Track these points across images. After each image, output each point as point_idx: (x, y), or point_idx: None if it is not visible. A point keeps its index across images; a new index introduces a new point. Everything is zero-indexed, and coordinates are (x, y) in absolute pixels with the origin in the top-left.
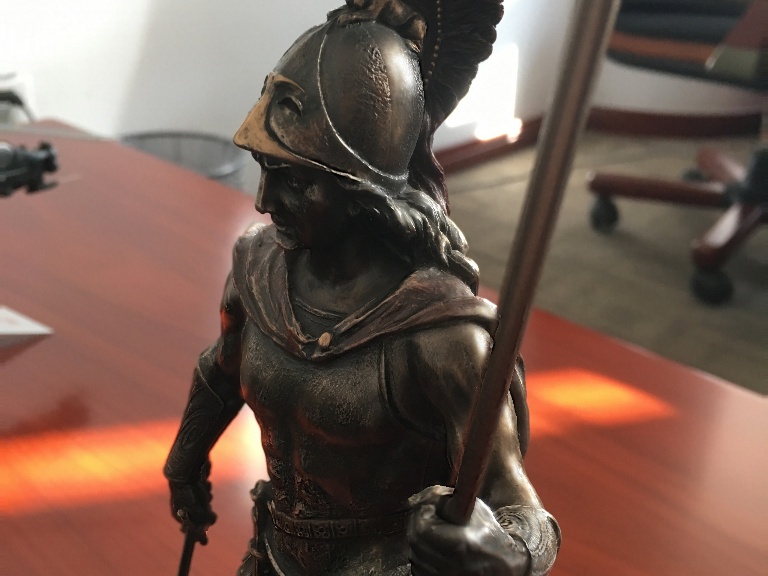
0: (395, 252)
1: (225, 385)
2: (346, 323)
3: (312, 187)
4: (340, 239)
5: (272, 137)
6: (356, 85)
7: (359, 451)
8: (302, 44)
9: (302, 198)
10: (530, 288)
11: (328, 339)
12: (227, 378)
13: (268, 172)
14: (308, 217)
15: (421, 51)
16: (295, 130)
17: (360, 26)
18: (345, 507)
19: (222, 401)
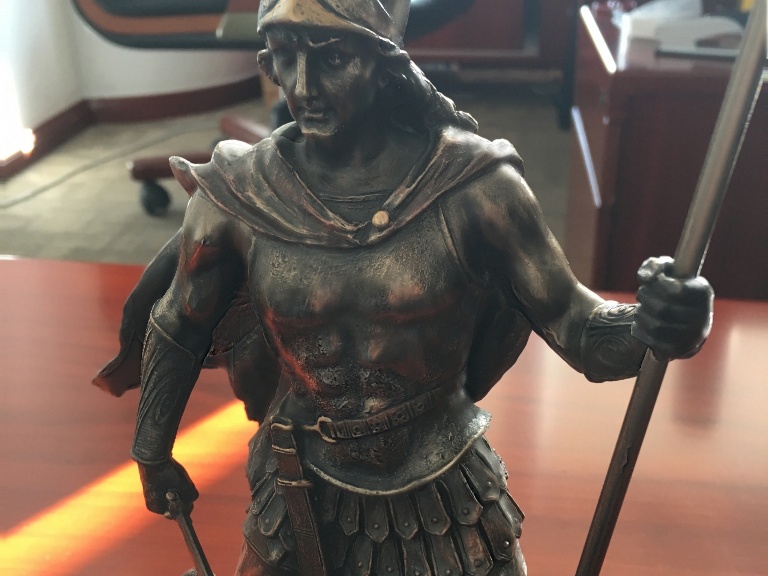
0: (397, 126)
1: (192, 337)
2: (398, 196)
3: (354, 61)
4: (368, 116)
5: (326, 9)
6: None
7: (434, 318)
8: None
9: (344, 75)
10: None
11: (386, 216)
12: (194, 328)
13: (308, 54)
14: (350, 94)
15: None
16: None
17: None
18: (419, 383)
19: (194, 355)
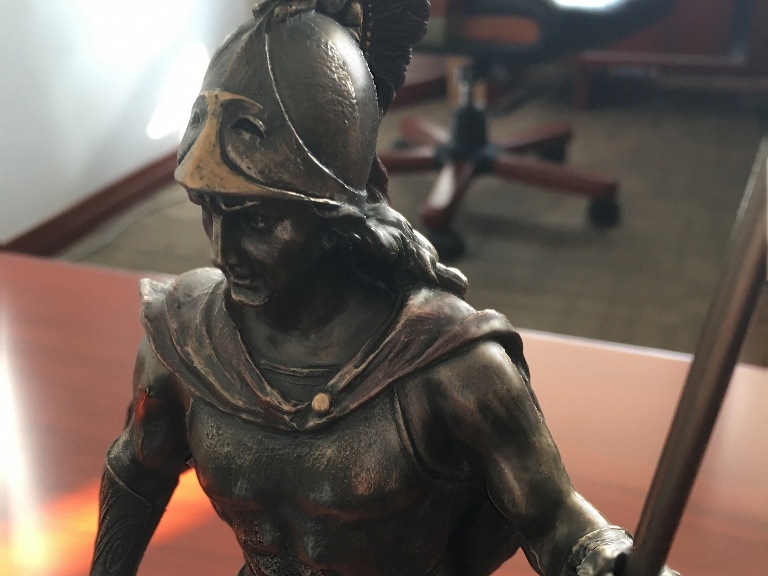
0: (365, 280)
1: (149, 483)
2: (344, 376)
3: (283, 223)
4: (313, 279)
5: (234, 171)
6: (320, 90)
7: (385, 520)
8: (240, 49)
9: (271, 239)
10: (759, 290)
11: (326, 401)
12: (151, 474)
13: (224, 216)
14: (280, 261)
15: (360, 40)
16: (262, 157)
17: (301, 18)
18: None
19: (149, 502)
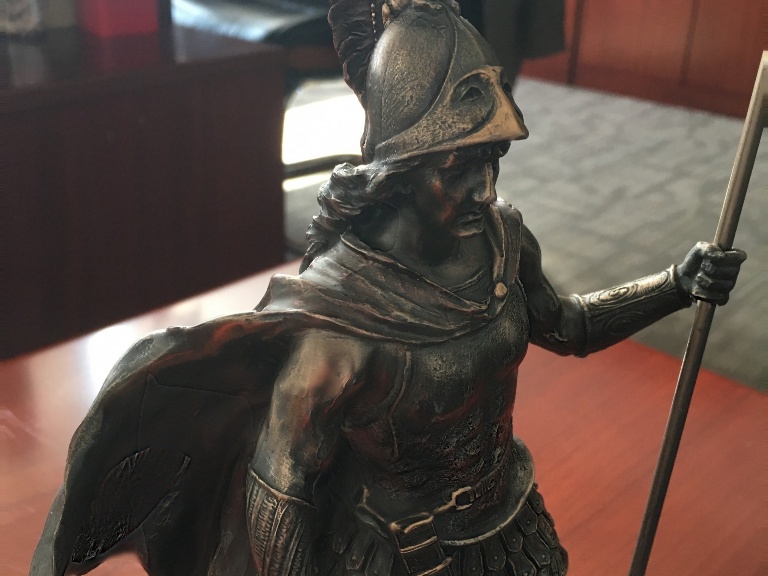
0: None
1: None
2: (501, 266)
3: None
4: None
5: None
6: None
7: None
8: (473, 36)
9: (495, 174)
10: None
11: (504, 286)
12: None
13: None
14: None
15: None
16: None
17: None
18: None
19: None
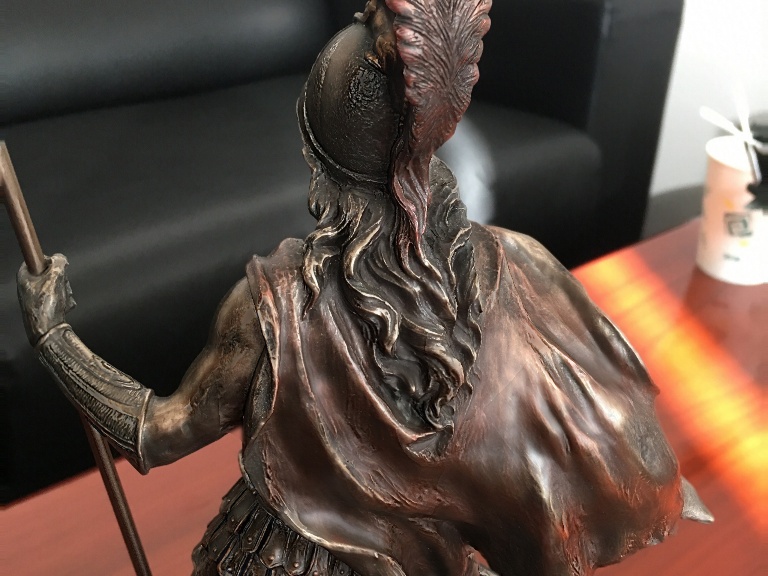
0: None
1: None
2: None
3: None
4: None
5: None
6: None
7: None
8: None
9: None
10: None
11: None
12: None
13: None
14: None
15: (384, 68)
16: None
17: None
18: None
19: None
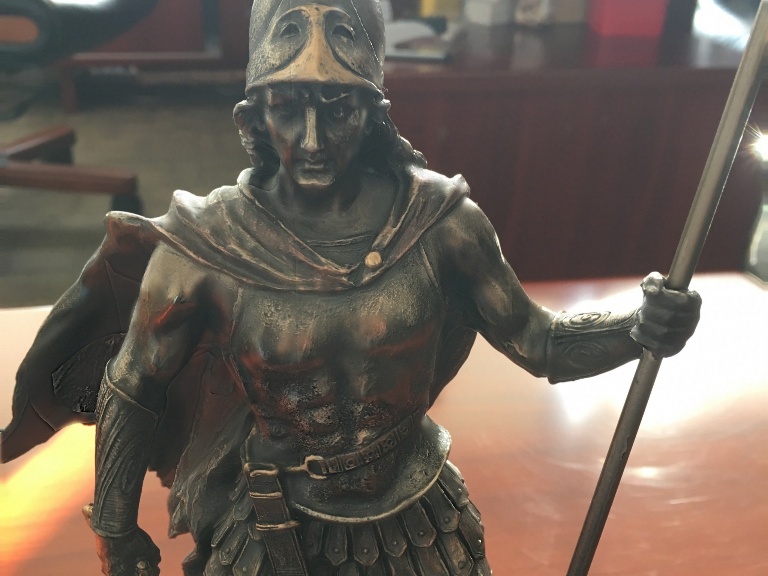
0: (360, 168)
1: (154, 397)
2: (386, 236)
3: (354, 113)
4: (353, 162)
5: (344, 67)
6: (373, 5)
7: (420, 346)
8: None
9: (345, 127)
10: None
11: (378, 256)
12: (157, 388)
13: (318, 109)
14: (349, 145)
15: None
16: (357, 56)
17: None
18: (404, 409)
19: (157, 416)
